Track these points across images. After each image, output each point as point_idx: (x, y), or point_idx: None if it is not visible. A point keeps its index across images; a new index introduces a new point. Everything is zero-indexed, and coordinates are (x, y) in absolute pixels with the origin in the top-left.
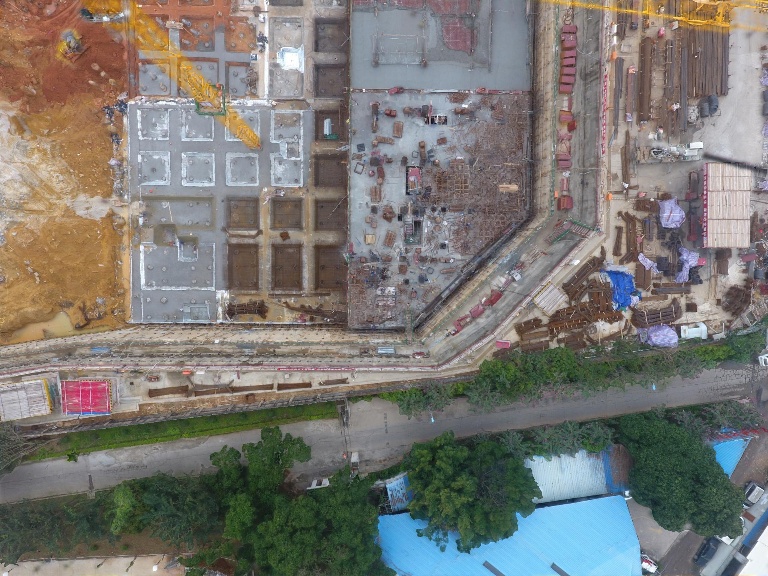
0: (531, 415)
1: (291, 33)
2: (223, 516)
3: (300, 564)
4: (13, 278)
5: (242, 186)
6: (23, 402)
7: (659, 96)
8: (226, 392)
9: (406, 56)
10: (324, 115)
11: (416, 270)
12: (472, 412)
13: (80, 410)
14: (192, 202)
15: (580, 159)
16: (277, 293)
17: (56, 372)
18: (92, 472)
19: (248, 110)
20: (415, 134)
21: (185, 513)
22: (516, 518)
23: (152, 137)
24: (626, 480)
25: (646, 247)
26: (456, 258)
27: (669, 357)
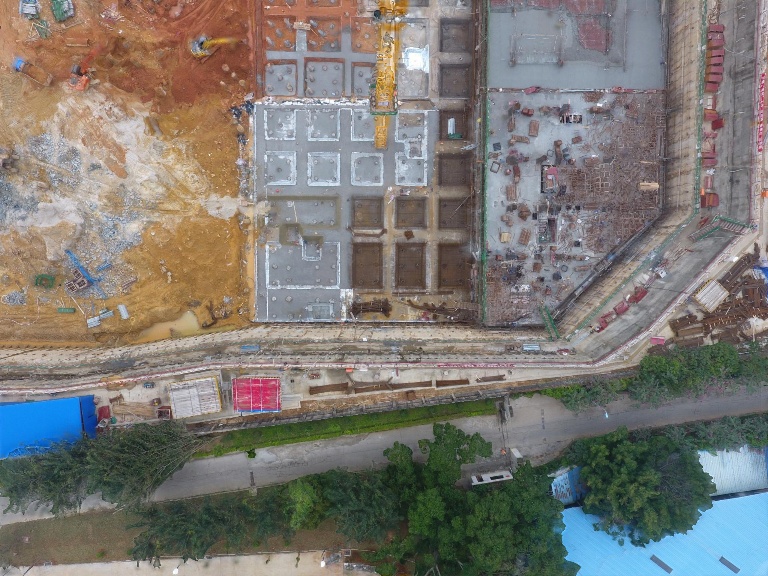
0: (686, 411)
1: (416, 33)
2: None
3: (506, 558)
4: (145, 278)
5: (367, 185)
6: (194, 400)
7: None
8: (385, 389)
9: (543, 56)
10: (448, 115)
11: (550, 268)
12: (628, 408)
13: (250, 407)
14: (317, 201)
15: (729, 157)
16: (401, 291)
17: (218, 370)
18: (254, 469)
19: None
20: (550, 133)
21: (374, 508)
22: (699, 512)
23: (278, 137)
24: None
25: None
26: (590, 256)
27: None
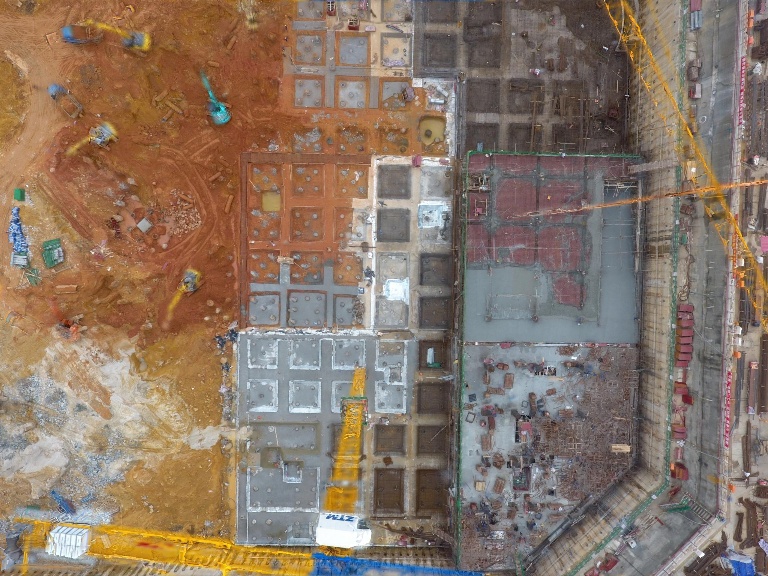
0: None
1: (397, 266)
2: None
3: None
4: (128, 508)
5: None
6: None
7: None
8: None
9: (518, 312)
10: (428, 345)
11: (524, 515)
12: None
13: None
14: (298, 426)
15: (698, 437)
16: (379, 516)
17: None
18: None
19: (354, 339)
20: (525, 385)
21: None
22: None
23: (261, 365)
24: None
25: (766, 532)
26: (563, 503)
27: None
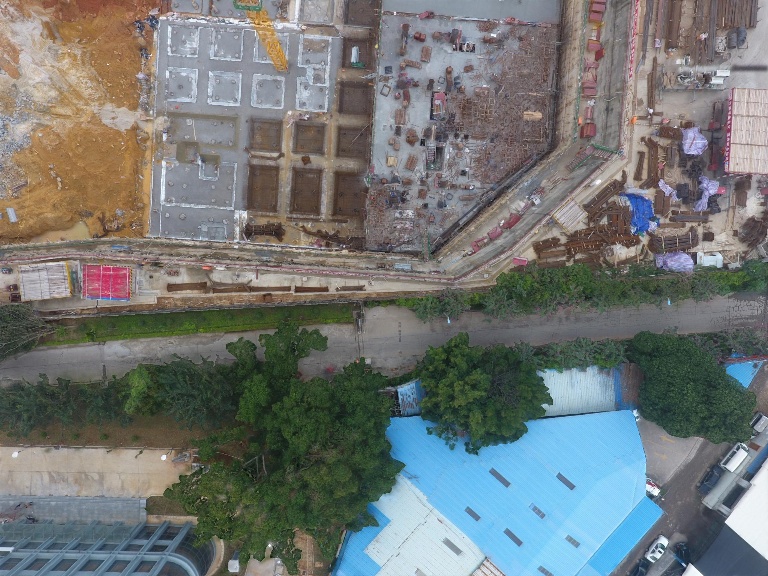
0: (544, 333)
1: None
2: (236, 403)
3: (313, 438)
4: (35, 182)
5: (267, 108)
6: (44, 283)
7: (688, 25)
8: (244, 291)
9: None
10: (352, 42)
11: (435, 195)
12: (486, 326)
13: (100, 295)
14: (216, 121)
15: (606, 86)
16: (295, 216)
17: (77, 260)
18: (106, 362)
19: (277, 33)
20: (443, 60)
21: (200, 392)
22: None
23: (181, 54)
24: (635, 399)
25: (667, 174)
26: (476, 186)
27: (684, 279)
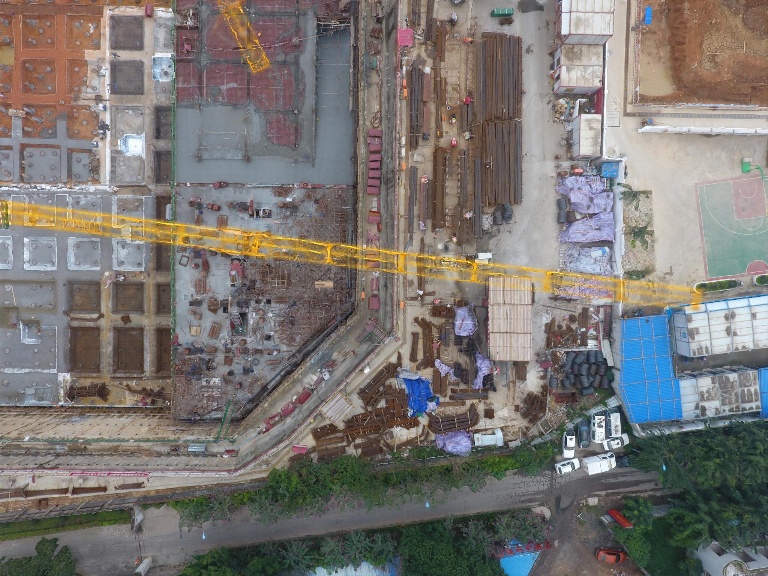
0: (327, 521)
1: (134, 120)
2: None
3: None
4: None
5: (84, 270)
6: None
7: (454, 204)
8: (20, 496)
9: (229, 151)
10: (165, 201)
11: (242, 361)
12: None
13: None
14: (35, 285)
15: None
16: (118, 376)
17: None
18: None
19: (90, 195)
20: (240, 227)
21: None
22: None
23: None
24: None
25: (443, 353)
26: (282, 349)
27: (456, 468)
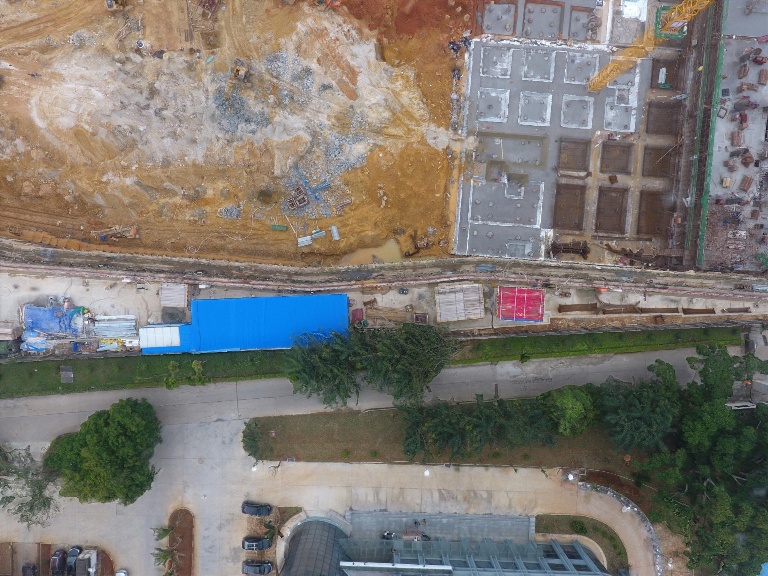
0: None
1: None
2: None
3: None
4: (359, 201)
5: (576, 128)
6: (460, 304)
7: None
8: (633, 312)
9: None
10: (661, 64)
11: (767, 216)
12: None
13: (513, 316)
14: (524, 141)
15: None
16: (601, 235)
17: (472, 281)
18: (499, 381)
19: (587, 54)
20: None
21: (658, 414)
22: None
23: (492, 75)
24: None
25: None
26: None
27: None
